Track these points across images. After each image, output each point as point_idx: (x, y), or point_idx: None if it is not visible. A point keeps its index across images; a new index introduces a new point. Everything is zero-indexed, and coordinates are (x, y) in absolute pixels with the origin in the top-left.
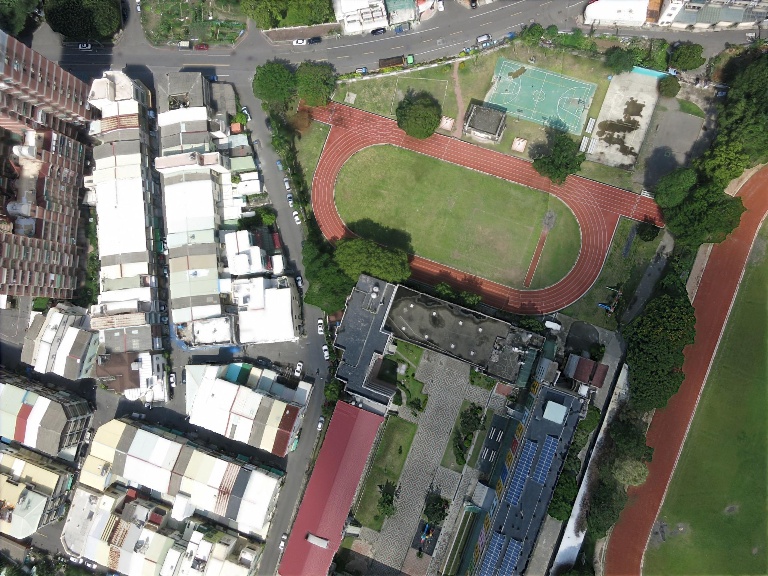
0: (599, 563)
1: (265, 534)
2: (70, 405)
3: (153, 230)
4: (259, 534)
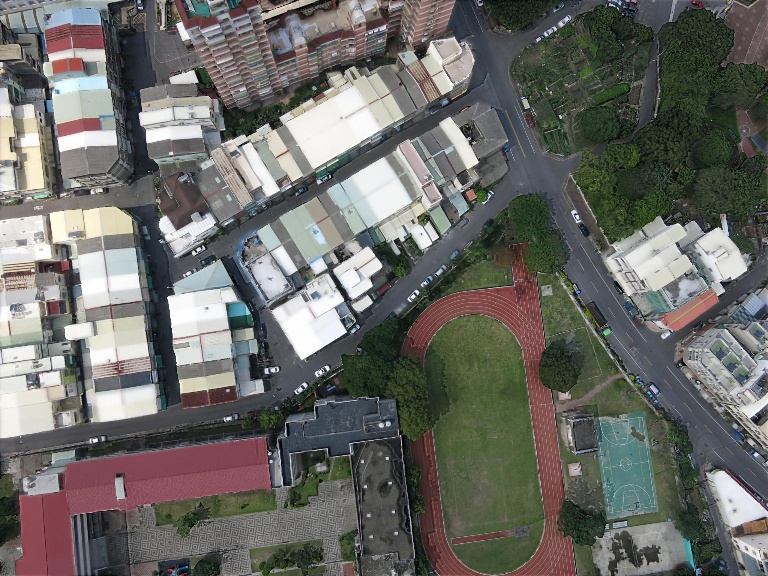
0: None
1: (96, 420)
2: (122, 164)
3: (336, 162)
4: (93, 414)
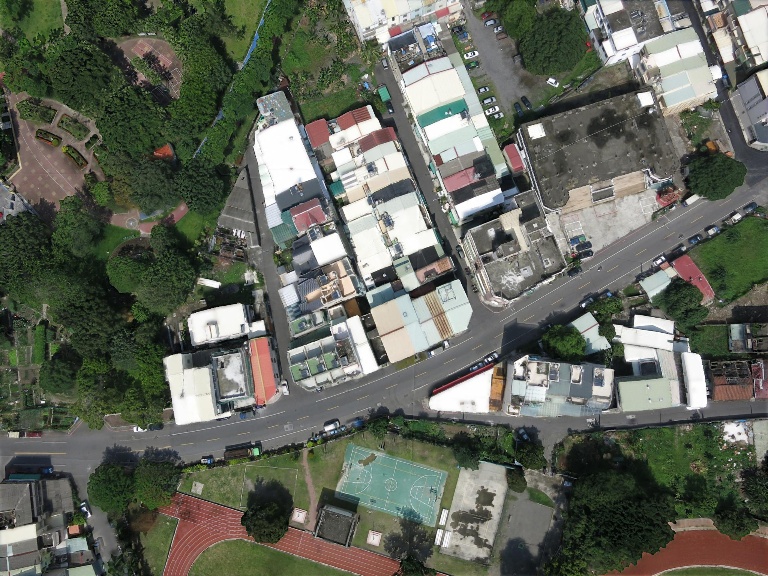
0: None
1: None
2: None
3: None
4: None
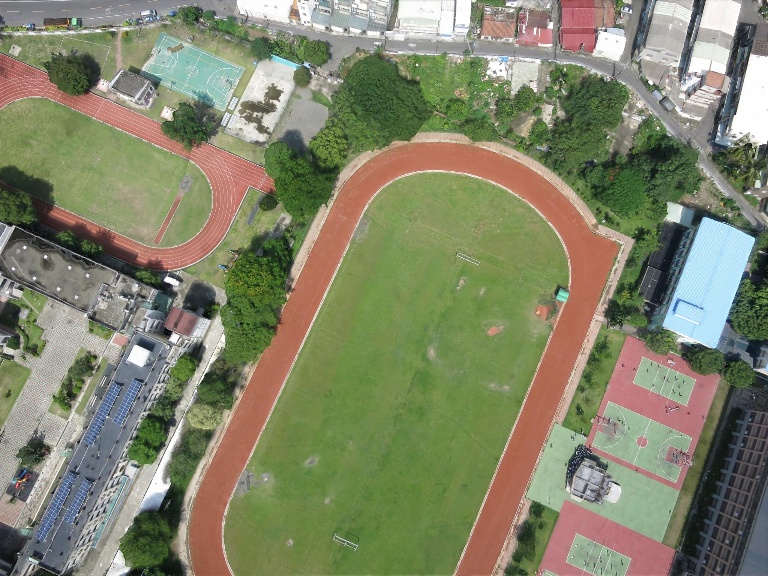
0: (187, 511)
1: None
2: None
3: None
4: None
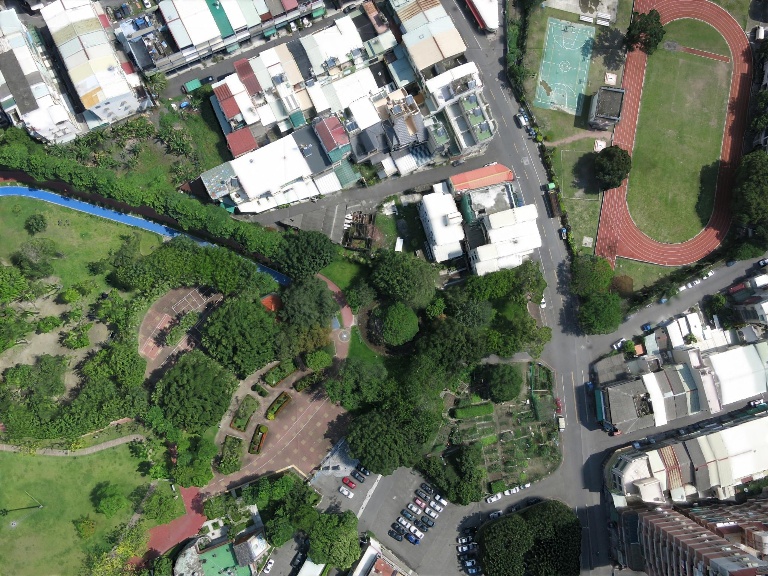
0: None
1: None
2: None
3: None
4: None
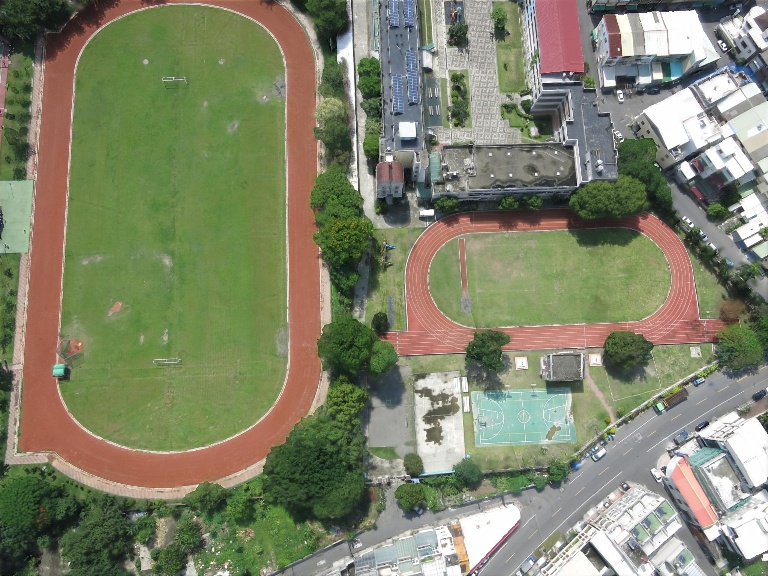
0: (316, 48)
1: None
2: None
3: None
4: None
